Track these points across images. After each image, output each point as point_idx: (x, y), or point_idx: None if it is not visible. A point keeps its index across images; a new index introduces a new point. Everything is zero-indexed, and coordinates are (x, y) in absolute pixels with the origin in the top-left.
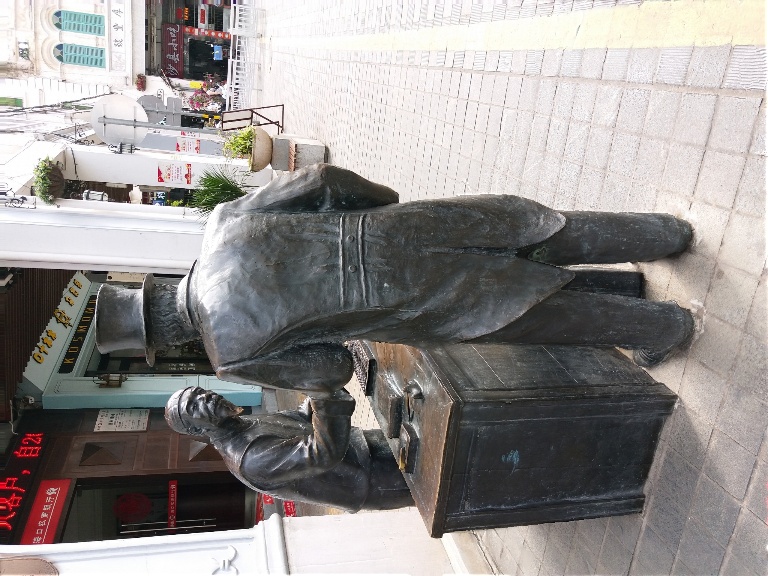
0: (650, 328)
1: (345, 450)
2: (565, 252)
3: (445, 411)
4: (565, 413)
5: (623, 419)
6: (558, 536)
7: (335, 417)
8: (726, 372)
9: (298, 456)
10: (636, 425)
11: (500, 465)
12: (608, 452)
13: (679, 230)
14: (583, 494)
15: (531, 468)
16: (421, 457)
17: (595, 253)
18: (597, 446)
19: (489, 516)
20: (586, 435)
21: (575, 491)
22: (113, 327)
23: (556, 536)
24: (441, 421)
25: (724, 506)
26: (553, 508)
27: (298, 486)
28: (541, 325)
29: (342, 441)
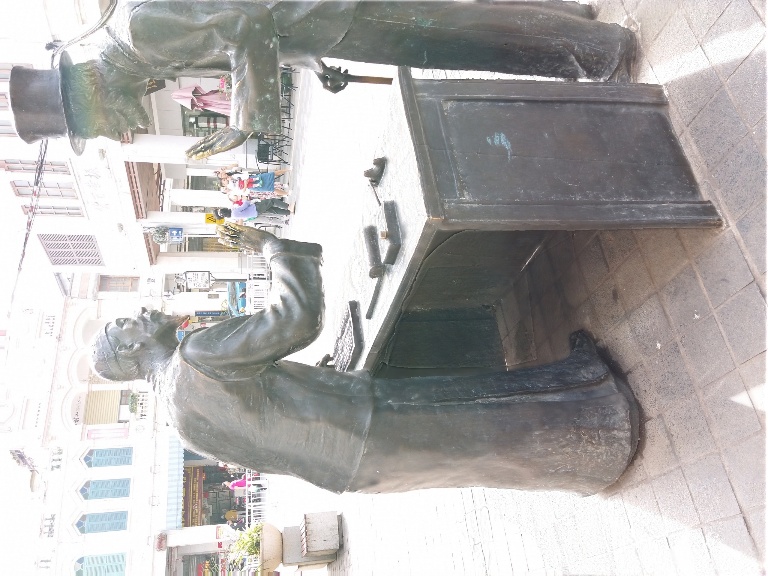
0: (582, 20)
1: (320, 305)
2: (472, 3)
3: (396, 89)
4: (538, 92)
5: (614, 108)
6: (688, 441)
7: (298, 258)
8: (672, 5)
9: (257, 316)
10: (635, 116)
11: (489, 149)
12: (622, 146)
13: (574, 1)
14: (623, 197)
15: (532, 157)
16: (400, 202)
17: (501, 4)
18: (603, 139)
19: (503, 208)
20: (580, 123)
21: (609, 192)
22: (28, 74)
23: (687, 446)
24: (397, 108)
25: (761, 62)
26: (590, 206)
27: (267, 389)
28: (464, 7)
29: (313, 291)
